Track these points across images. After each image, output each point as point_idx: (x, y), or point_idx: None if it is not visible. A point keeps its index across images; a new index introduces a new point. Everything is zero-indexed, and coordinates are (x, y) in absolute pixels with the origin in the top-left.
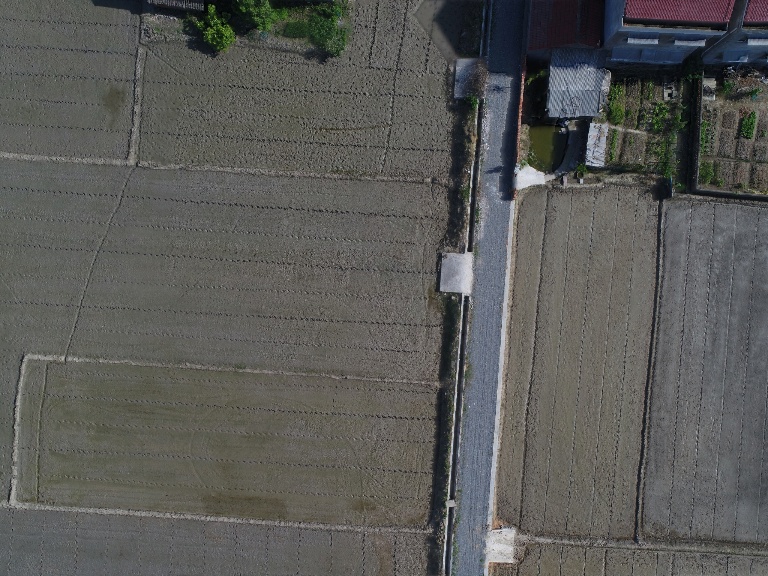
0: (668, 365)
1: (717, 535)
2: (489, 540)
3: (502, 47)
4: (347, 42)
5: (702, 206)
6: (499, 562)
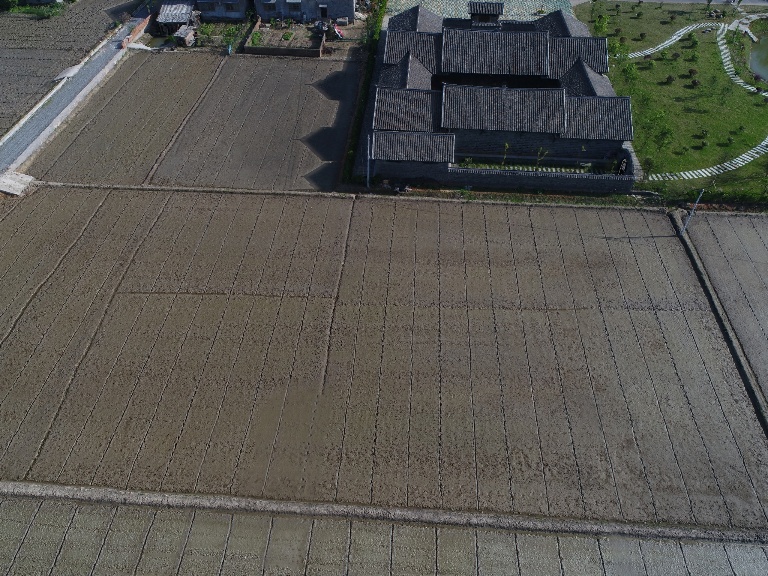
0: (206, 109)
1: (217, 184)
2: (4, 176)
3: (145, 12)
4: (58, 15)
5: (252, 58)
6: (5, 193)
